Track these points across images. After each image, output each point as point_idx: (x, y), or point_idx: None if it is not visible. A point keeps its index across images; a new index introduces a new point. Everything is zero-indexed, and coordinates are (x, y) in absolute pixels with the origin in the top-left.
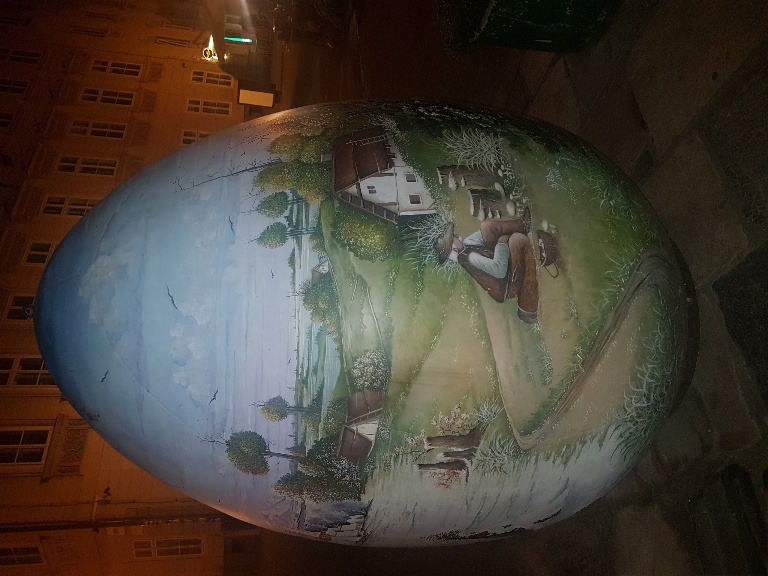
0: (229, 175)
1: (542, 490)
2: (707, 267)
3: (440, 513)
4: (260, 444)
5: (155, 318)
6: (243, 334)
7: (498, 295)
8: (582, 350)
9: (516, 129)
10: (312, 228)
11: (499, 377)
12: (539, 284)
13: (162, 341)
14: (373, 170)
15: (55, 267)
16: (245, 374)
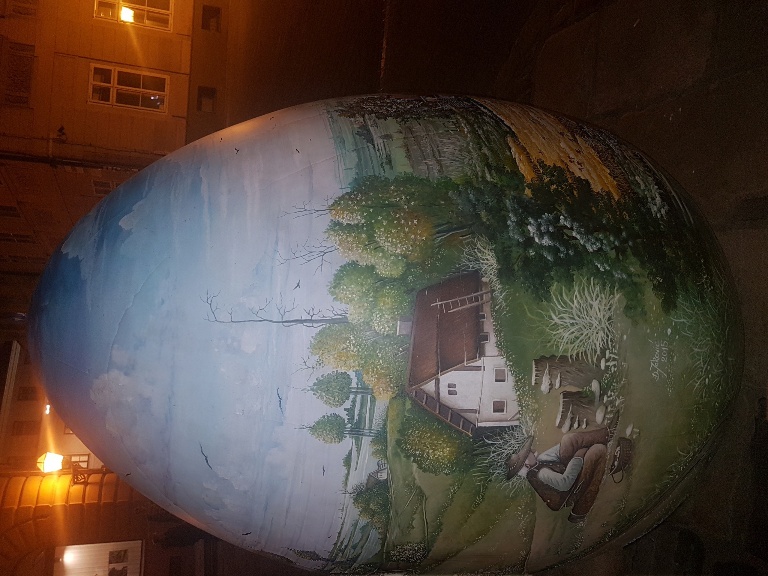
0: (278, 322)
1: None
2: (764, 379)
3: None
4: (287, 560)
5: (185, 465)
6: (284, 509)
7: (555, 505)
8: (614, 530)
9: (638, 267)
10: (375, 431)
11: (529, 556)
12: (600, 492)
13: (193, 485)
14: (458, 360)
15: (52, 332)
16: (281, 533)
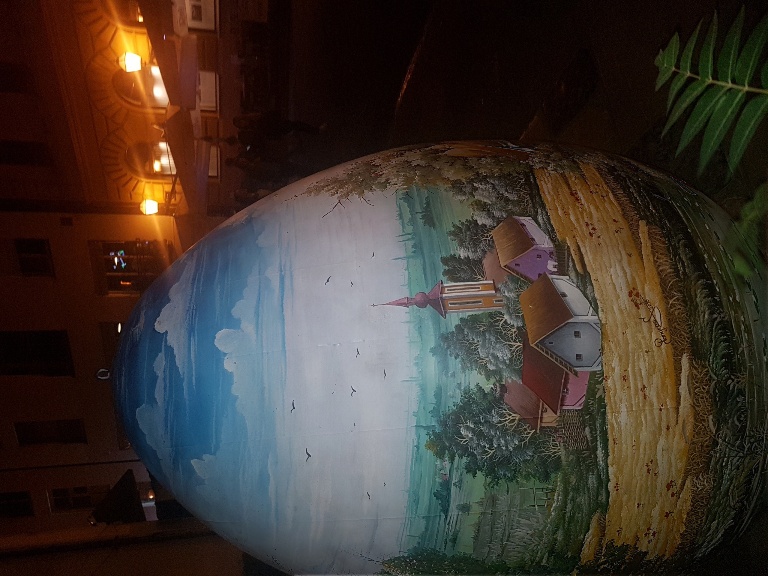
0: None
1: None
2: None
3: None
4: None
5: None
6: None
7: None
8: None
9: None
10: None
11: None
12: None
13: None
14: None
15: None
16: None
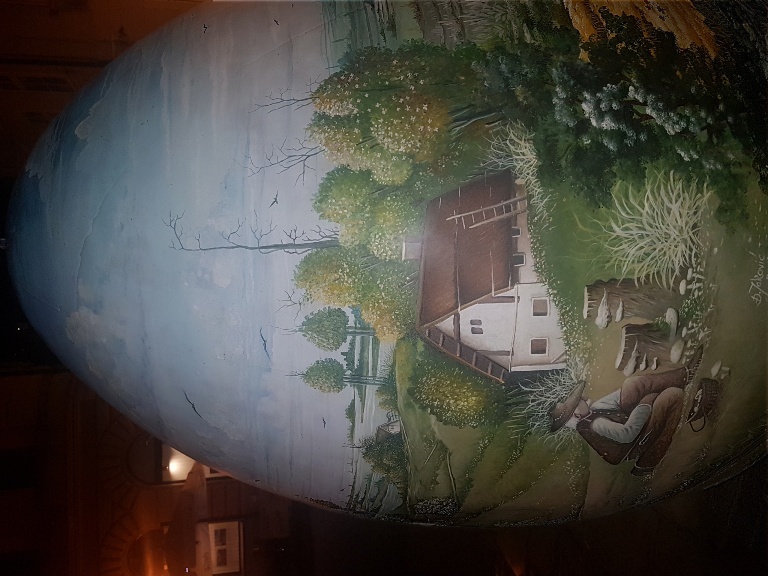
0: (254, 248)
1: None
2: None
3: None
4: None
5: (174, 412)
6: (287, 461)
7: (615, 458)
8: (691, 479)
9: (739, 152)
10: (381, 378)
11: (583, 509)
12: (673, 442)
13: (187, 432)
14: (484, 289)
15: (22, 263)
16: (290, 483)
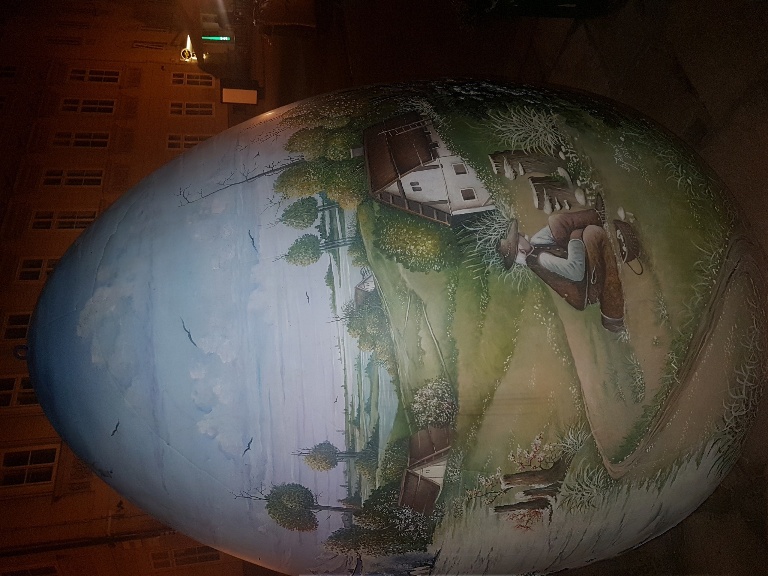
0: (243, 181)
1: (633, 520)
2: None
3: (518, 556)
4: (306, 497)
5: (170, 358)
6: (278, 371)
7: (577, 301)
8: (676, 358)
9: (568, 103)
10: (350, 238)
11: (585, 398)
12: (623, 284)
13: (181, 385)
14: (414, 163)
15: (47, 303)
16: (284, 418)
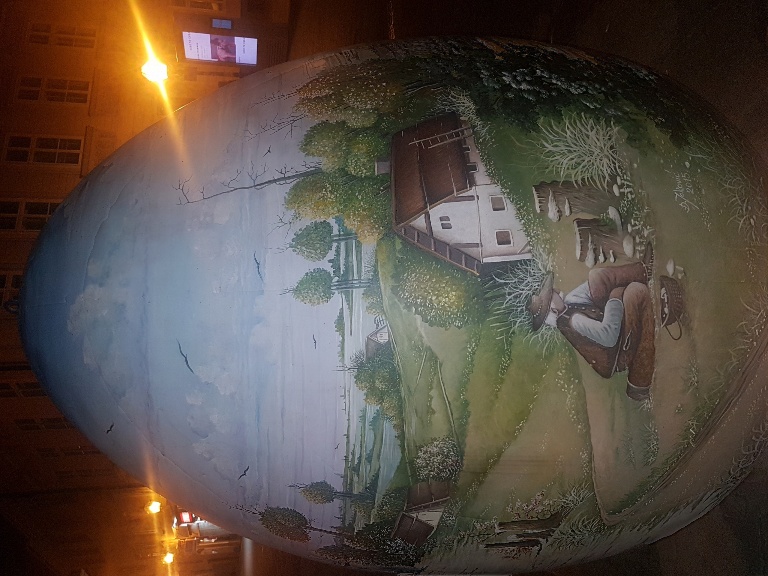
0: (251, 187)
1: (618, 549)
2: None
3: (501, 572)
4: (300, 520)
5: (166, 378)
6: (278, 411)
7: (604, 369)
8: (696, 424)
9: (633, 107)
10: (366, 280)
11: (594, 463)
12: (657, 351)
13: (176, 406)
14: (447, 191)
15: (35, 280)
16: (282, 455)
